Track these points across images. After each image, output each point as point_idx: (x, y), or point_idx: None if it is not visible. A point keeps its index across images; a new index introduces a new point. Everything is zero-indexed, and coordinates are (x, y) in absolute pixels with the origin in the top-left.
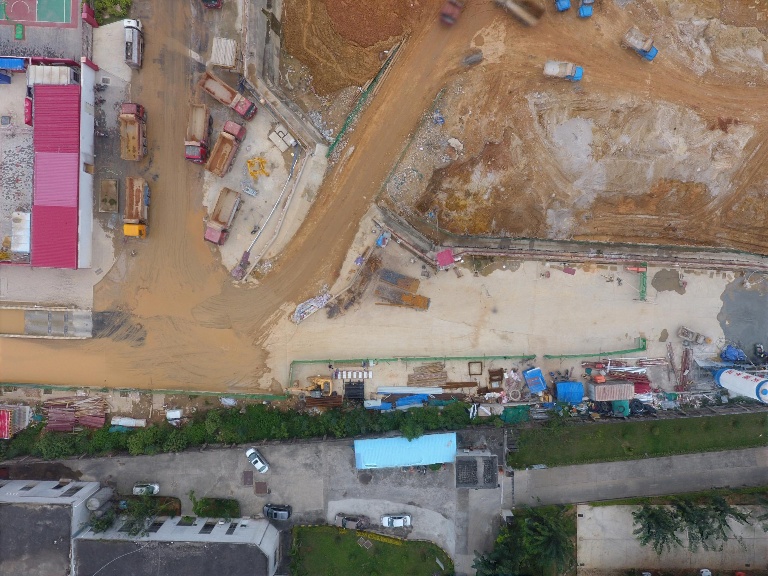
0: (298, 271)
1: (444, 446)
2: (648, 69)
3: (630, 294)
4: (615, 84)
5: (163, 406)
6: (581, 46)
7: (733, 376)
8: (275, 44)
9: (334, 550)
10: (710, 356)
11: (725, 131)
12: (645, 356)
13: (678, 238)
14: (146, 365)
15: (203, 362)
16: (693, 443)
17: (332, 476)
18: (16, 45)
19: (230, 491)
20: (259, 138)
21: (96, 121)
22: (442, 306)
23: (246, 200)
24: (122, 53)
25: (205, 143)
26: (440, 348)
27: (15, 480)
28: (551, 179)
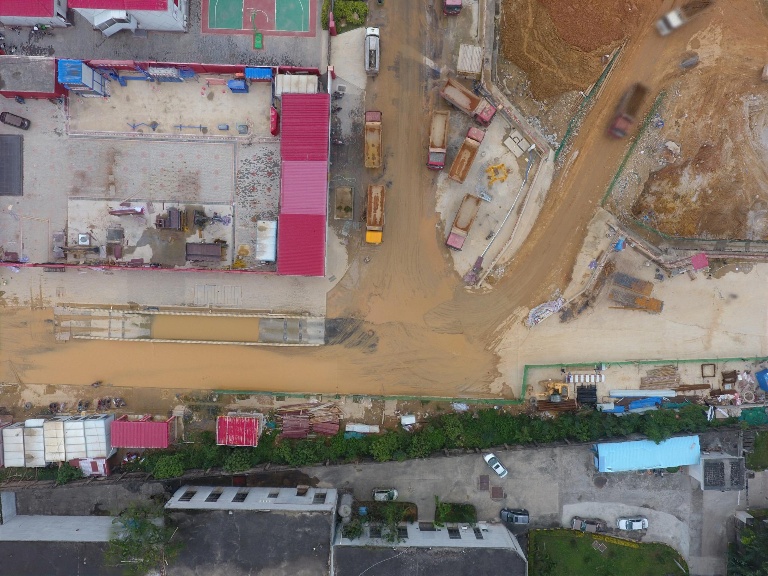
0: (529, 276)
1: (688, 449)
2: None
3: None
4: None
5: (396, 412)
6: None
7: None
8: None
9: (569, 553)
10: None
11: None
12: None
13: None
14: (378, 371)
15: (435, 367)
16: None
17: (567, 480)
18: (254, 54)
19: (466, 496)
20: (493, 144)
21: (333, 129)
22: (675, 309)
23: (480, 206)
24: (358, 61)
25: None
26: (673, 351)
27: (253, 487)
28: (756, 181)
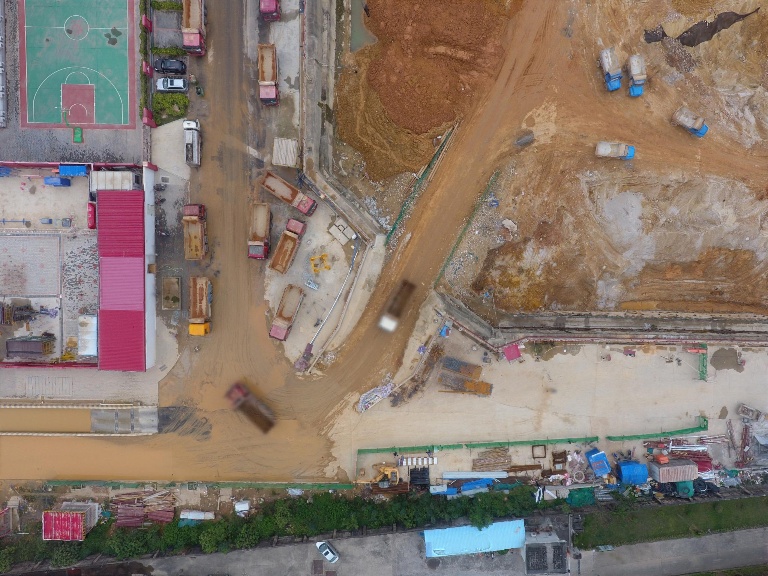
0: (361, 361)
1: (513, 533)
2: (698, 145)
3: (689, 374)
4: (665, 161)
5: (231, 498)
6: (631, 124)
7: None
8: (329, 133)
9: None
10: None
11: None
12: (706, 434)
13: (725, 301)
14: (212, 458)
15: (269, 453)
16: (755, 518)
17: (401, 562)
18: (75, 148)
19: None
20: (319, 232)
21: (157, 220)
22: (505, 391)
23: (308, 293)
24: (180, 152)
25: (267, 241)
26: (503, 433)
27: None
28: (601, 252)
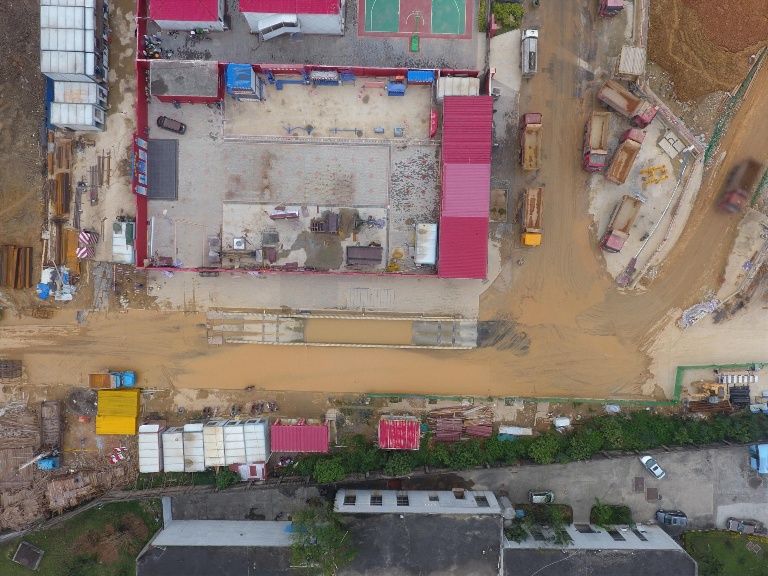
0: (681, 277)
1: None
2: None
3: None
4: None
5: (548, 414)
6: None
7: None
8: None
9: (723, 555)
10: None
11: None
12: None
13: None
14: (530, 373)
15: (587, 369)
16: None
17: (722, 481)
18: (410, 57)
19: (621, 498)
20: (647, 145)
21: None
22: None
23: None
24: (512, 63)
25: None
26: None
27: (409, 491)
28: None
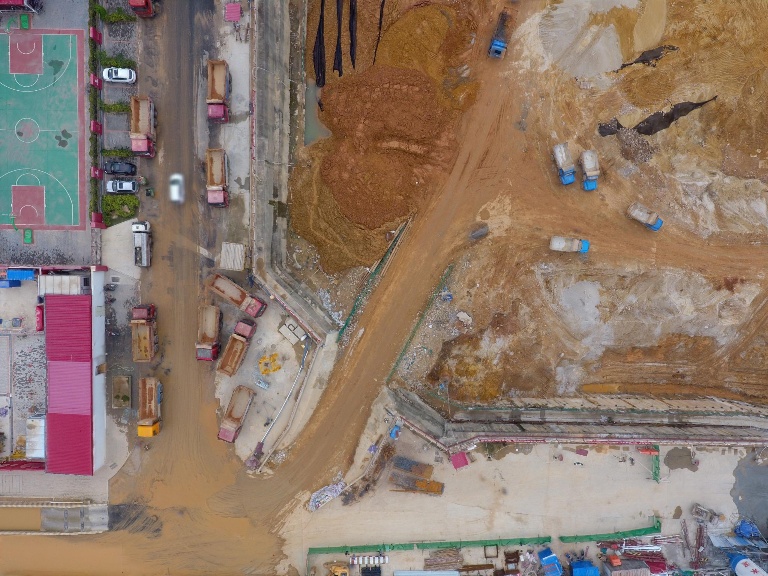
0: (312, 458)
1: None
2: (653, 237)
3: (643, 473)
4: (621, 253)
5: None
6: (586, 217)
7: (749, 572)
8: (282, 228)
9: None
10: (724, 531)
11: (731, 290)
12: (660, 534)
13: (687, 384)
14: (163, 556)
15: (220, 551)
16: None
17: None
18: (25, 248)
19: None
20: (269, 331)
21: (107, 320)
22: (456, 491)
23: (258, 392)
24: (131, 252)
25: (216, 342)
26: (455, 532)
27: None
28: (559, 340)
